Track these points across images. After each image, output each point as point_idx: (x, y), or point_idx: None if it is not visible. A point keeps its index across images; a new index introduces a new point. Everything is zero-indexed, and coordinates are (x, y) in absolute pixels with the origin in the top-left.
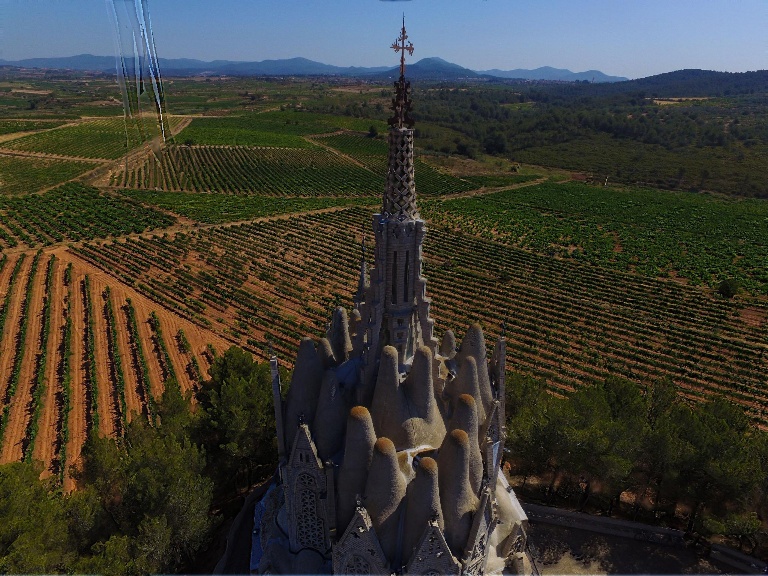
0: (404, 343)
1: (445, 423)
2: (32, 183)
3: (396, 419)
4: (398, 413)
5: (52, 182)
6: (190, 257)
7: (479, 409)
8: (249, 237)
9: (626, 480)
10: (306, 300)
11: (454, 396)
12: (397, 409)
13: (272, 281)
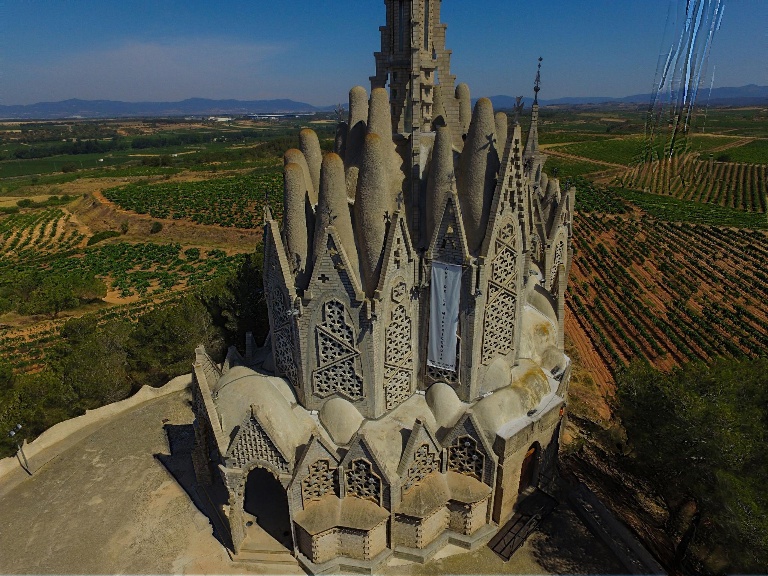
0: (397, 104)
1: (408, 209)
2: (549, 173)
3: (345, 165)
4: (347, 158)
5: (564, 174)
6: (607, 235)
7: (441, 203)
8: (691, 236)
9: (763, 560)
10: (687, 297)
11: (427, 182)
12: (347, 153)
13: (670, 274)
